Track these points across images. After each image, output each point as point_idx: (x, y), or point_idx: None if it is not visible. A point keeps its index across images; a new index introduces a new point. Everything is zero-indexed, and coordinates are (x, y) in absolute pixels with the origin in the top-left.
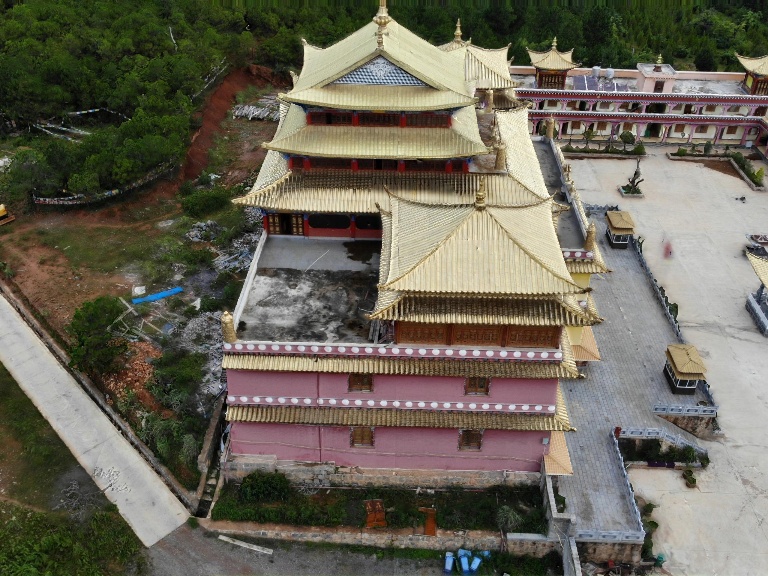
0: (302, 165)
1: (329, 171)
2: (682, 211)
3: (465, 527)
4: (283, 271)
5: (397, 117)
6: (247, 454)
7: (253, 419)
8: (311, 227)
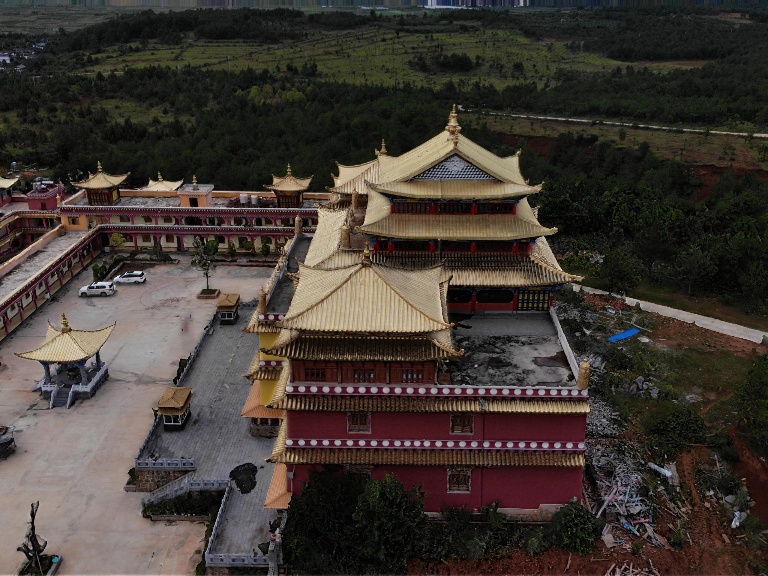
0: None
1: None
2: (1, 526)
3: None
4: None
5: None
6: None
7: None
8: None
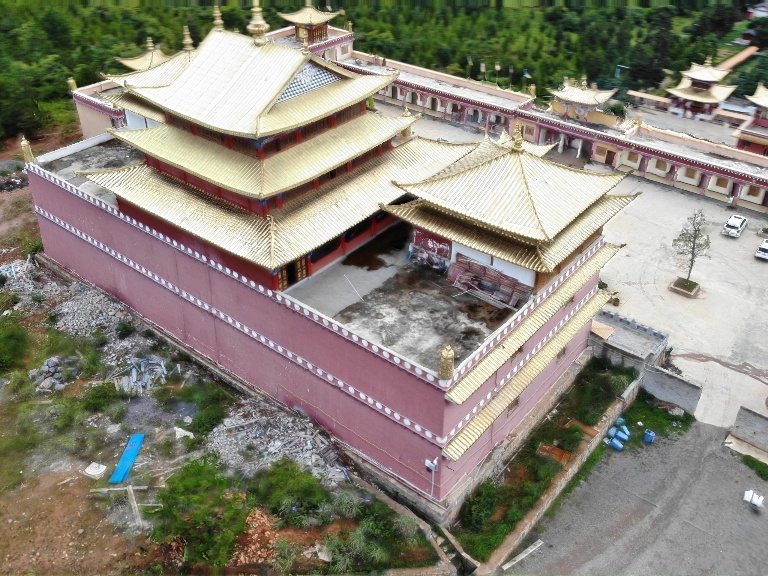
0: (275, 205)
1: (299, 199)
2: None
3: (601, 413)
4: (348, 312)
5: (329, 119)
6: (449, 491)
7: (471, 443)
8: (312, 264)
